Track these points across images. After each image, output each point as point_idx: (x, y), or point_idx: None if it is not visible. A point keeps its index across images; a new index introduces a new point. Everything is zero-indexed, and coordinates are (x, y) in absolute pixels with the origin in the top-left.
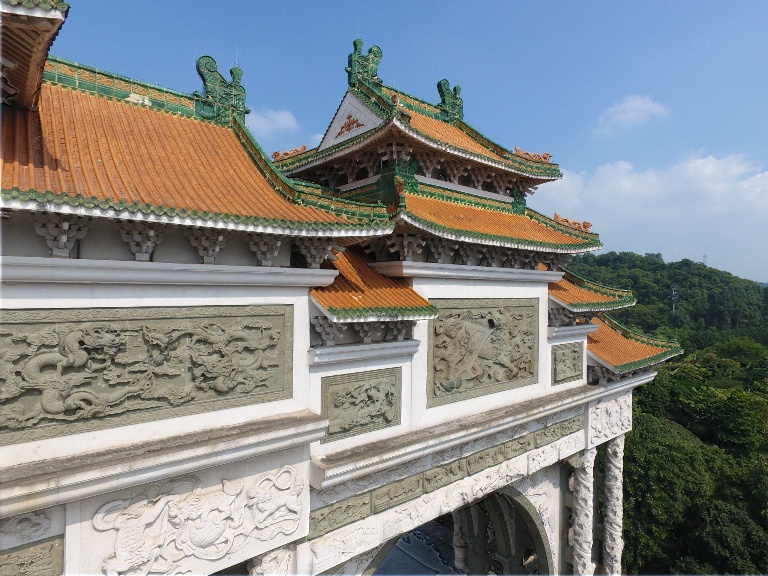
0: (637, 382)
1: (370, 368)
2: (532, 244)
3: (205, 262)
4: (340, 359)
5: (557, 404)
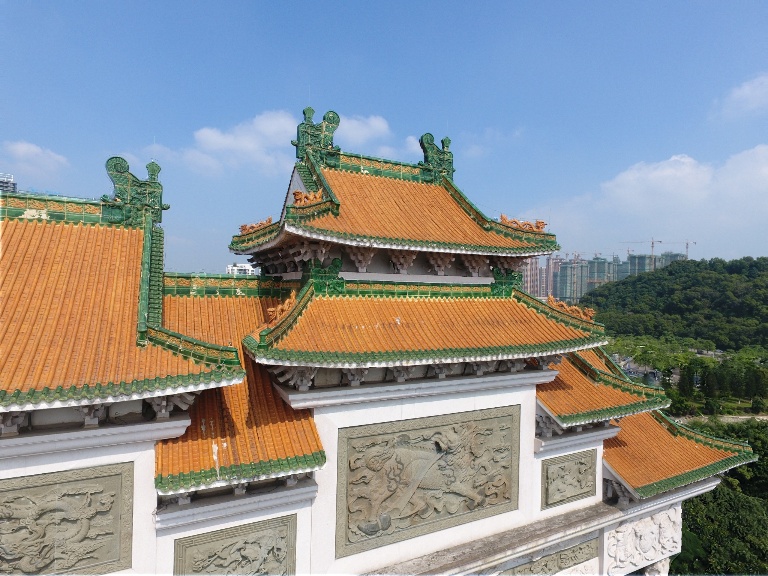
0: (684, 496)
1: (248, 520)
2: (488, 354)
3: (3, 433)
4: (195, 520)
5: (537, 543)
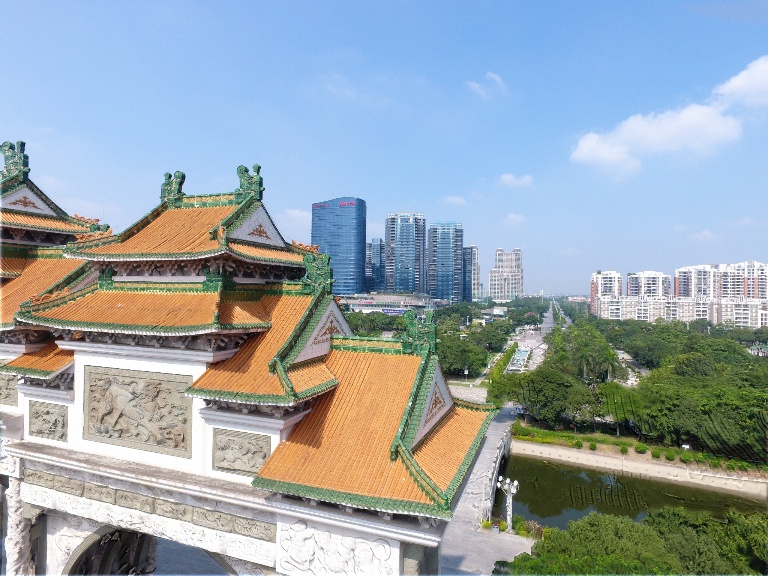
0: (370, 528)
1: (51, 402)
2: (128, 329)
3: None
4: None
5: (176, 484)
